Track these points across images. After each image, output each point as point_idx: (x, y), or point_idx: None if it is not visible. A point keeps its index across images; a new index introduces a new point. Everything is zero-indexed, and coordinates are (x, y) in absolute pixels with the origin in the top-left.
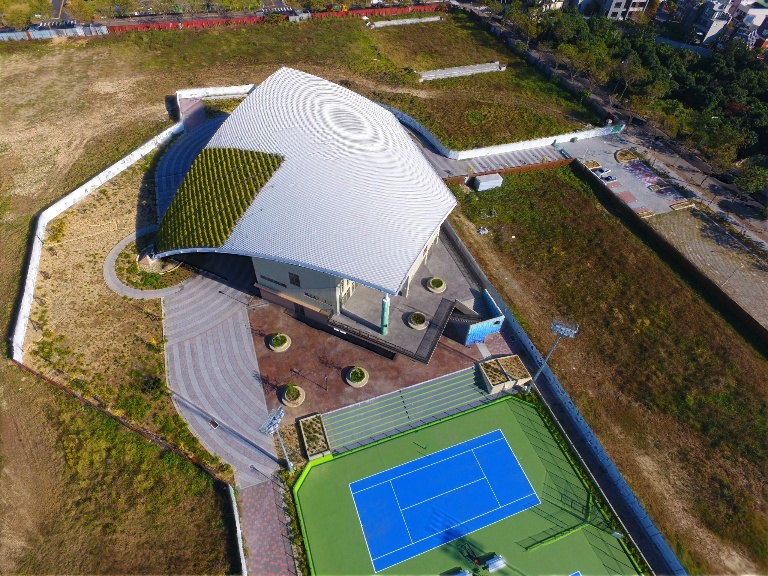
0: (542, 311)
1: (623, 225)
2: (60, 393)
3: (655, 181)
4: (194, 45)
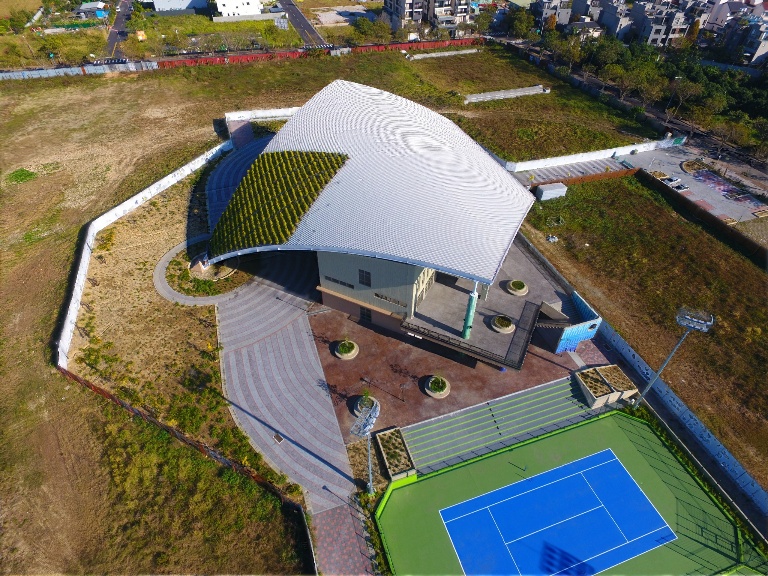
0: (634, 319)
1: (705, 232)
2: (106, 403)
3: (730, 190)
4: (240, 76)
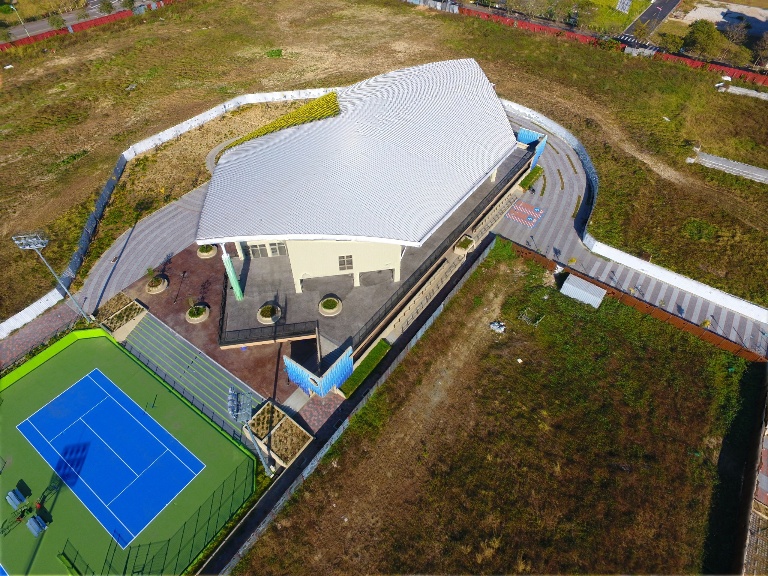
0: (417, 443)
1: (711, 493)
2: None
3: None
4: (505, 41)
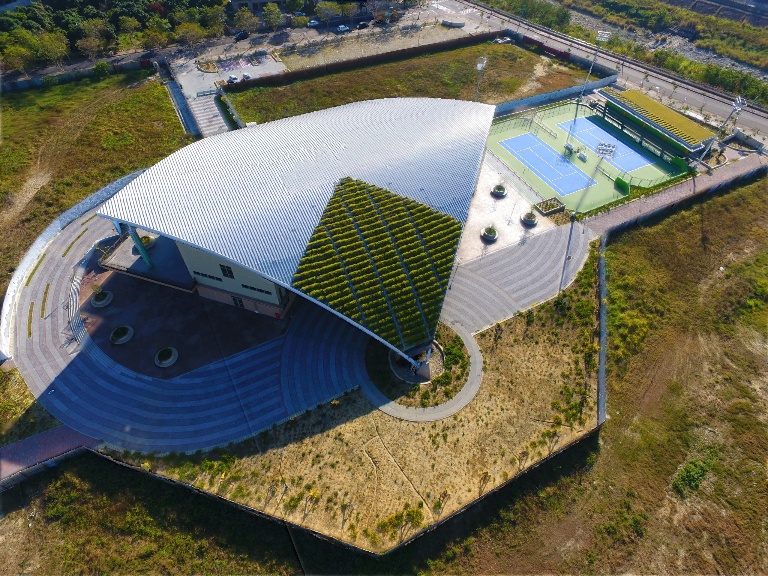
0: None
1: None
2: None
3: (245, 62)
4: None
